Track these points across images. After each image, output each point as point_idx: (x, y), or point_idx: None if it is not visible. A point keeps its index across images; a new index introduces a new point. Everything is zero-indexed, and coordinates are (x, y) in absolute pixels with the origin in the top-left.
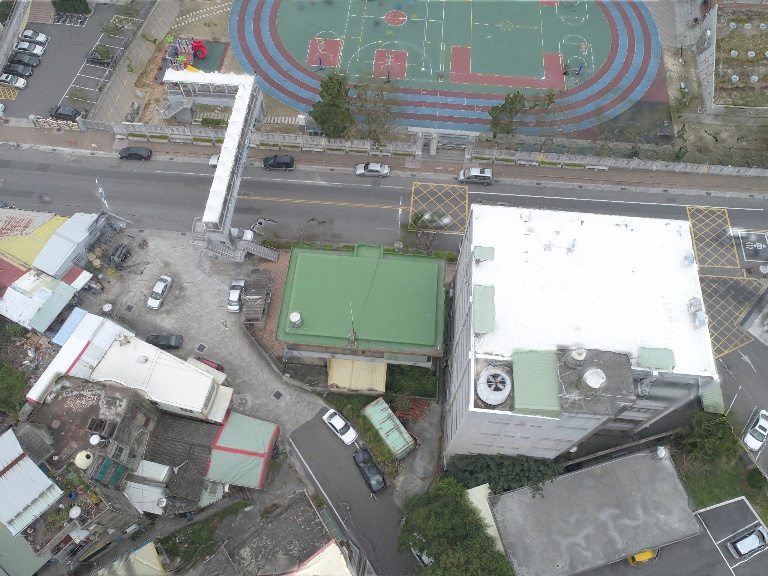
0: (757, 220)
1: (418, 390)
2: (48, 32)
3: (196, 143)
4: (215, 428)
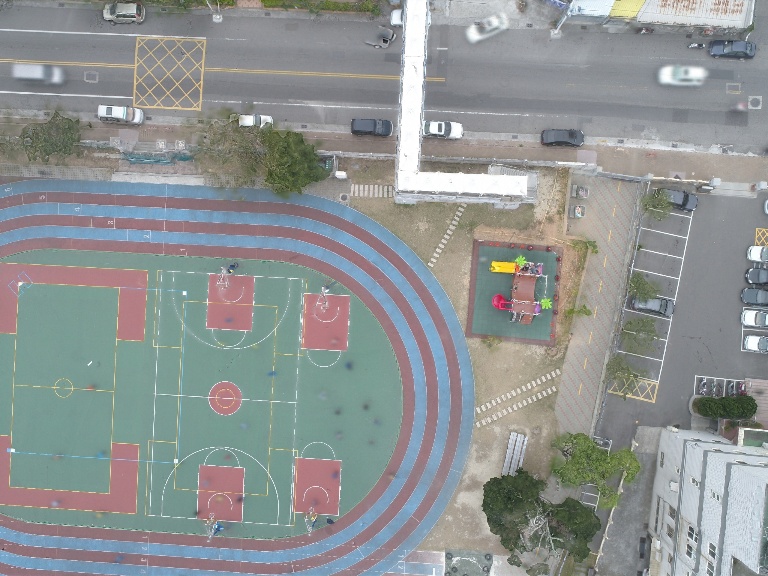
0: None
1: None
2: (748, 361)
3: None
4: None
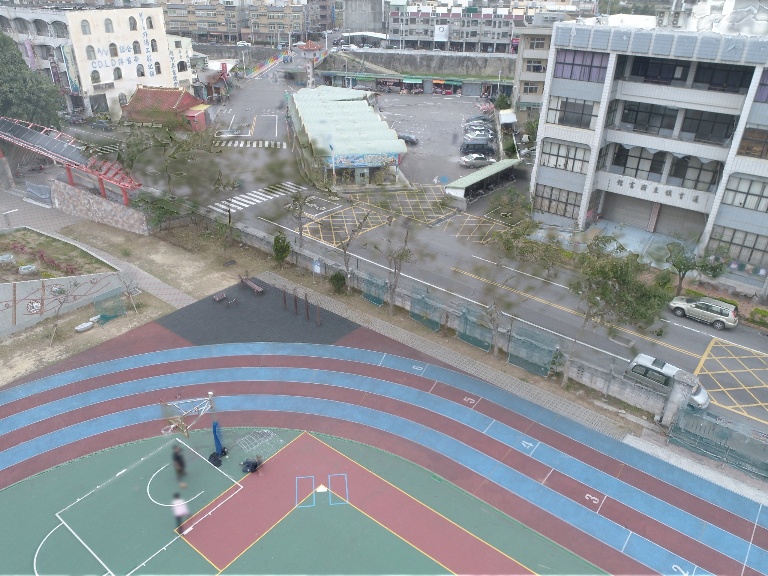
0: (280, 214)
1: None
2: None
3: None
4: None
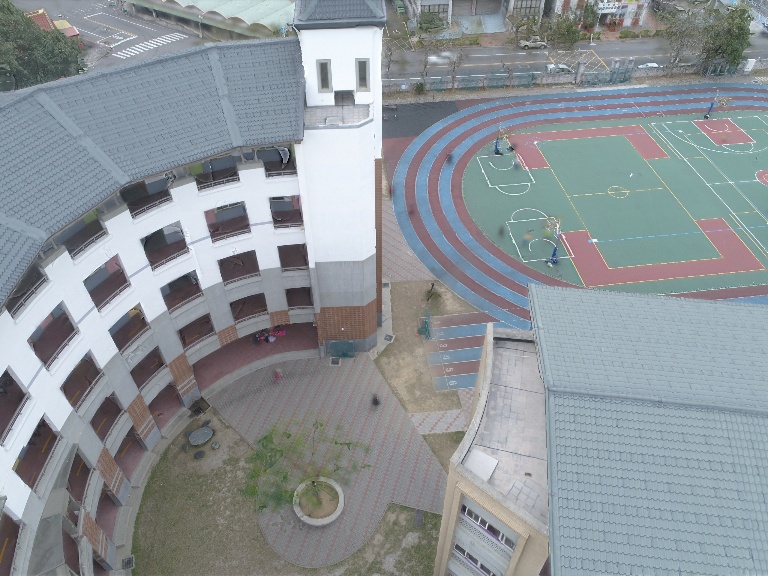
0: None
1: None
2: None
3: None
4: None
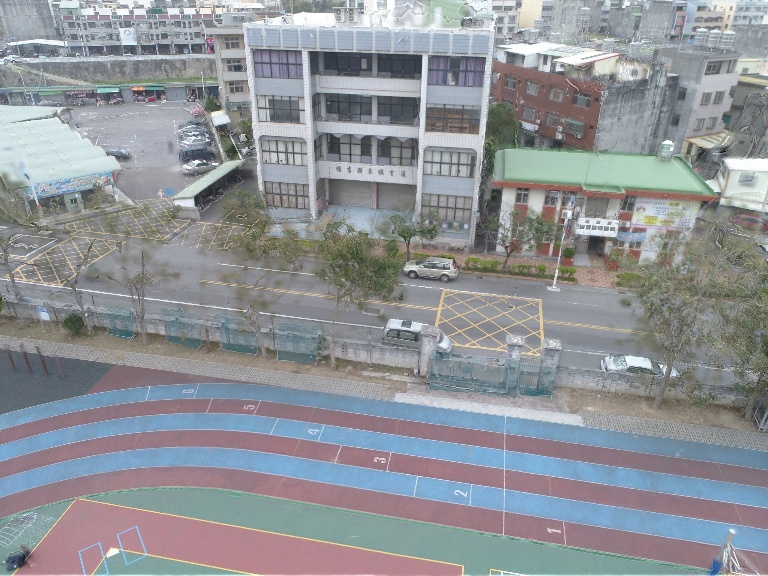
0: None
1: None
2: None
3: None
4: None
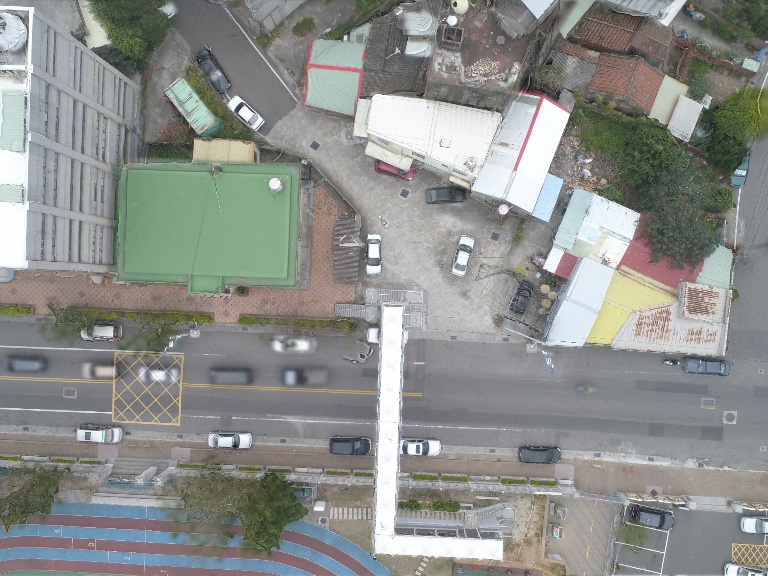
0: None
1: (165, 152)
2: None
3: (464, 476)
4: (366, 93)
